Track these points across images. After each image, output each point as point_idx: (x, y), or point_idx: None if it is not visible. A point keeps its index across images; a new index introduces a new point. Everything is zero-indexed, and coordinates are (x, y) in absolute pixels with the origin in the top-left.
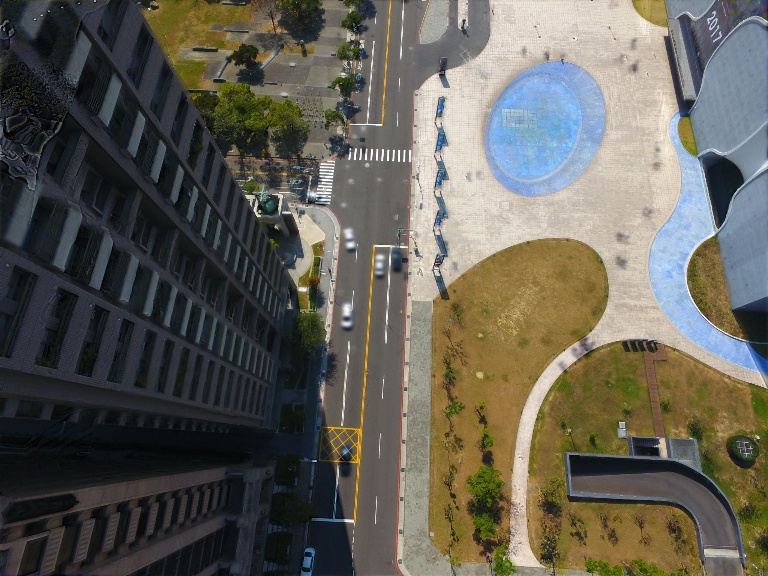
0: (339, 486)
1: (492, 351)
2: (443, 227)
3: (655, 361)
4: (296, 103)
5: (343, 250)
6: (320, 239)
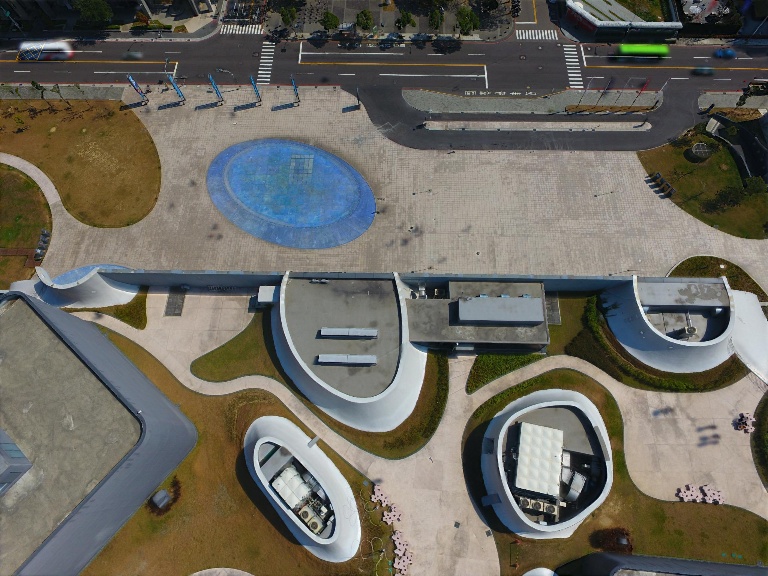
0: (5, 52)
1: (70, 138)
2: (187, 107)
3: (27, 257)
4: None
5: (177, 44)
6: (189, 29)
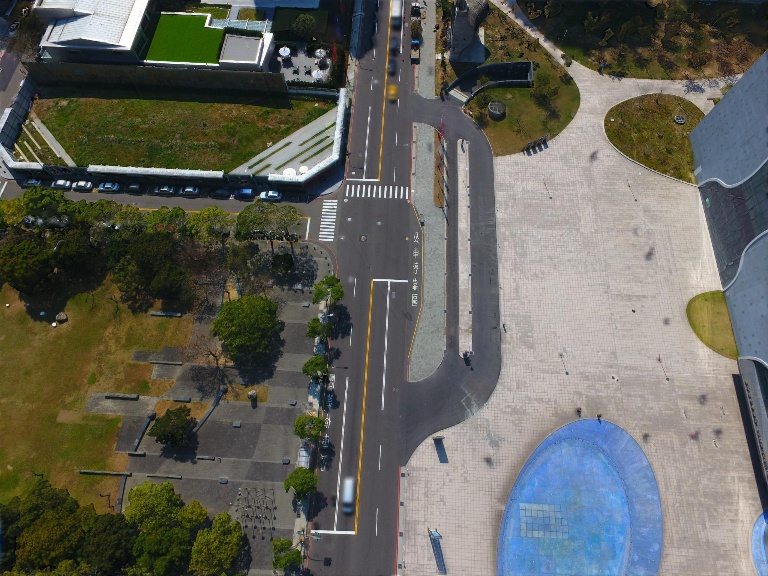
0: None
1: None
2: None
3: None
4: (235, 518)
5: None
6: None
